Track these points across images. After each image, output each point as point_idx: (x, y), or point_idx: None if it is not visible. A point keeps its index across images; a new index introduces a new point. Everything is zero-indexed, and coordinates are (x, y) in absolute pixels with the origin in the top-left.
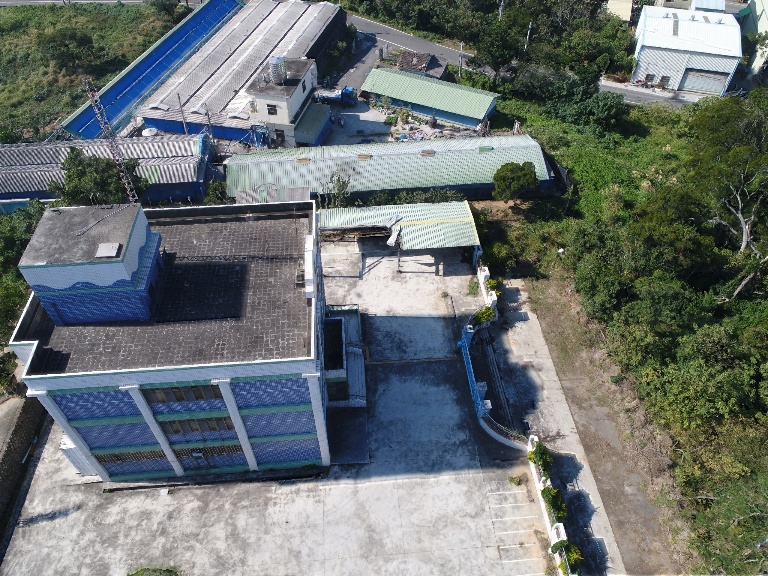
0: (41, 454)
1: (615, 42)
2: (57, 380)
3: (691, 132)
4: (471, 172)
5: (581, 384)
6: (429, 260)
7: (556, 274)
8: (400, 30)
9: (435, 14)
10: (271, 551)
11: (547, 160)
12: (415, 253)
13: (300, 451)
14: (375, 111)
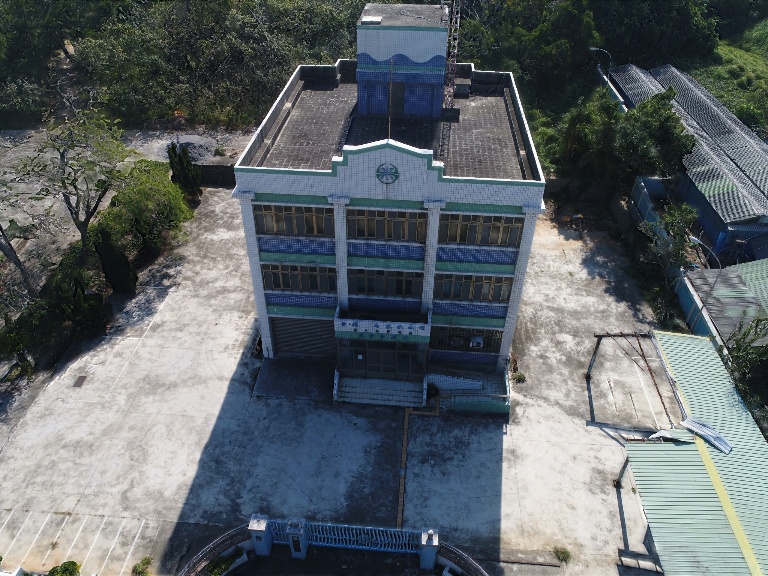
0: None
1: None
2: None
3: None
4: None
5: None
6: None
7: None
8: None
9: None
10: (194, 313)
11: None
12: None
13: None
14: None
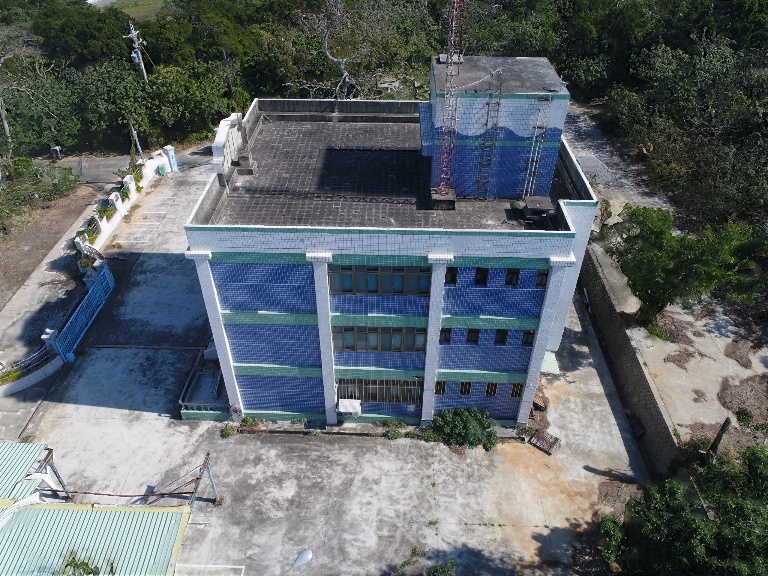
0: None
1: None
2: None
3: None
4: None
5: None
6: None
7: None
8: None
9: None
10: None
11: None
12: None
13: None
14: None
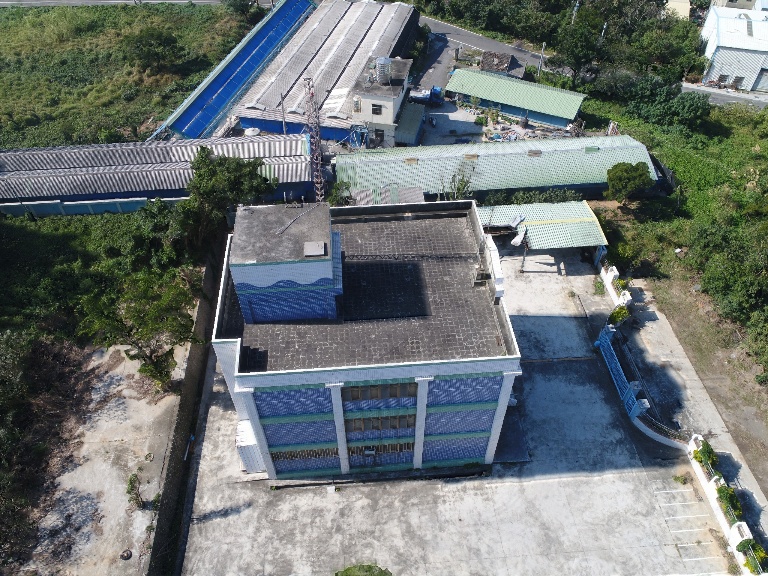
0: (201, 451)
1: (686, 42)
2: (268, 377)
3: None
4: (579, 172)
5: (723, 384)
6: (549, 260)
7: (677, 274)
8: (469, 30)
9: (503, 14)
10: (450, 548)
11: (651, 160)
12: (534, 253)
13: (467, 449)
14: (463, 111)
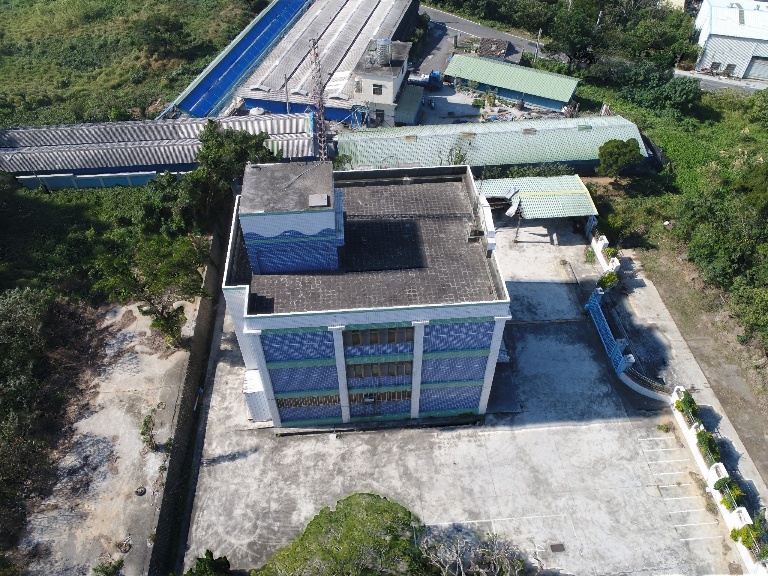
0: (210, 403)
1: (679, 31)
2: (274, 319)
3: (765, 116)
4: (572, 149)
5: (706, 344)
6: (542, 231)
7: (665, 245)
8: (468, 19)
9: (501, 4)
10: (445, 489)
11: None
12: (527, 224)
13: (461, 399)
14: (461, 94)
